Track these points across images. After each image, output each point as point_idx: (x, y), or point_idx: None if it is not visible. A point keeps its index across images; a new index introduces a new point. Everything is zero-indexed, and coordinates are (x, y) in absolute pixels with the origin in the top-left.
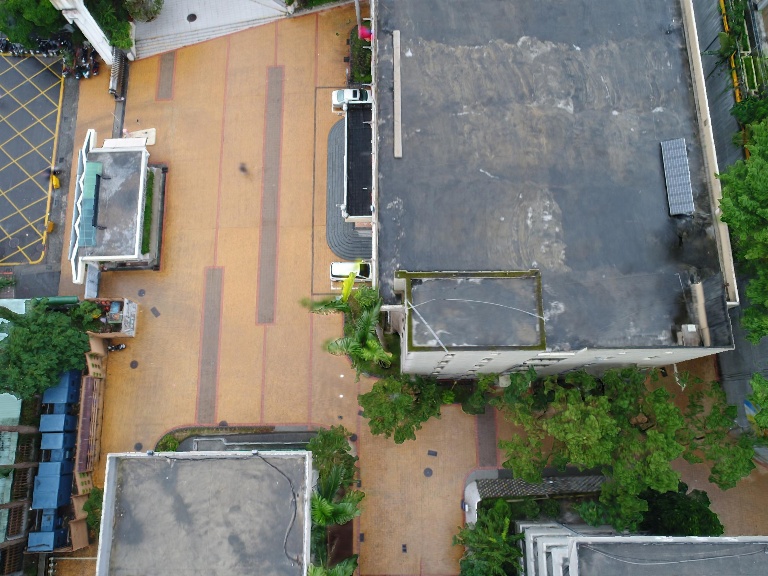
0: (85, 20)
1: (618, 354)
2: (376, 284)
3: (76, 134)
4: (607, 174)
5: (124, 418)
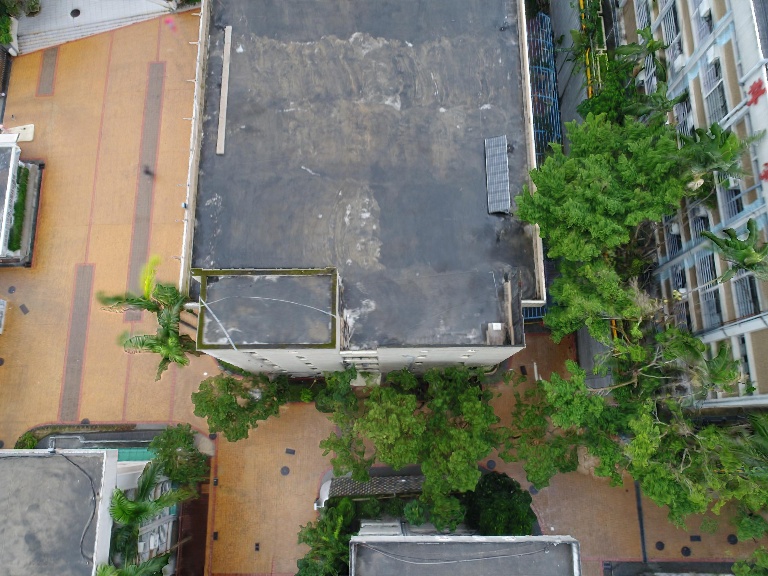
0: None
1: (421, 352)
2: (187, 281)
3: None
4: (429, 171)
5: None
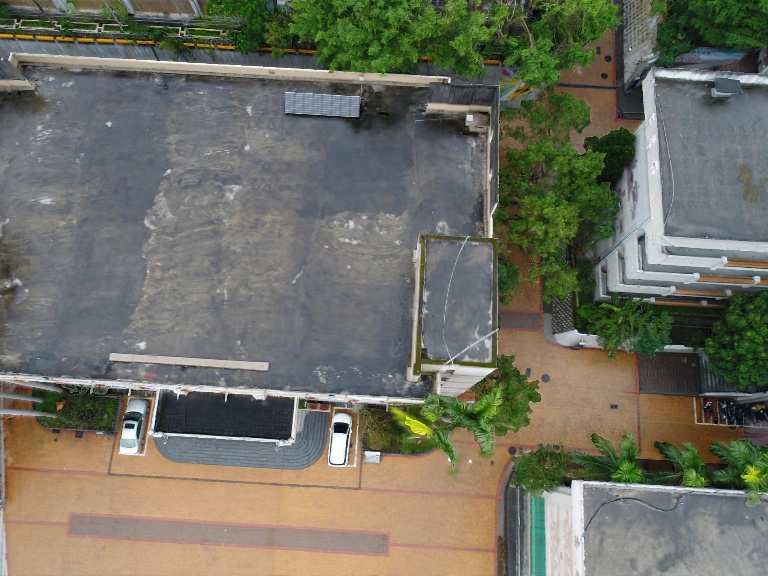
0: None
1: None
2: None
3: None
4: (311, 165)
5: None
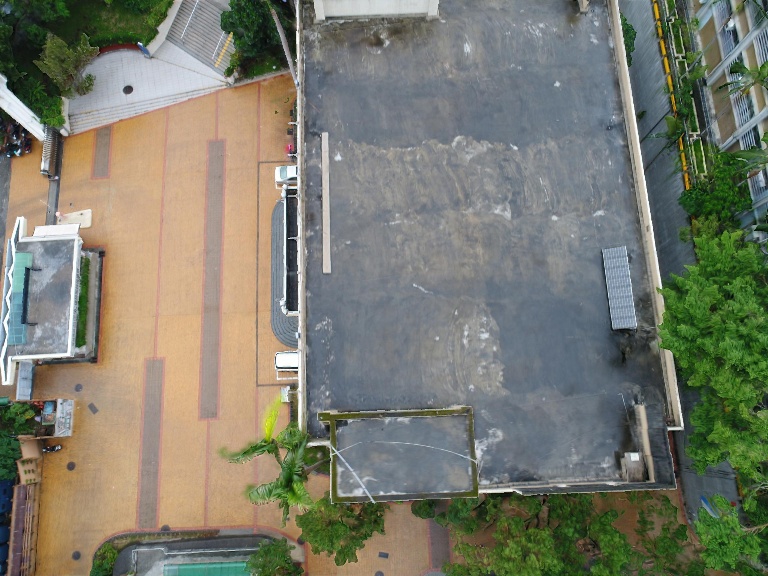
0: (9, 104)
1: None
2: (304, 416)
3: (8, 216)
4: (546, 286)
5: (61, 525)
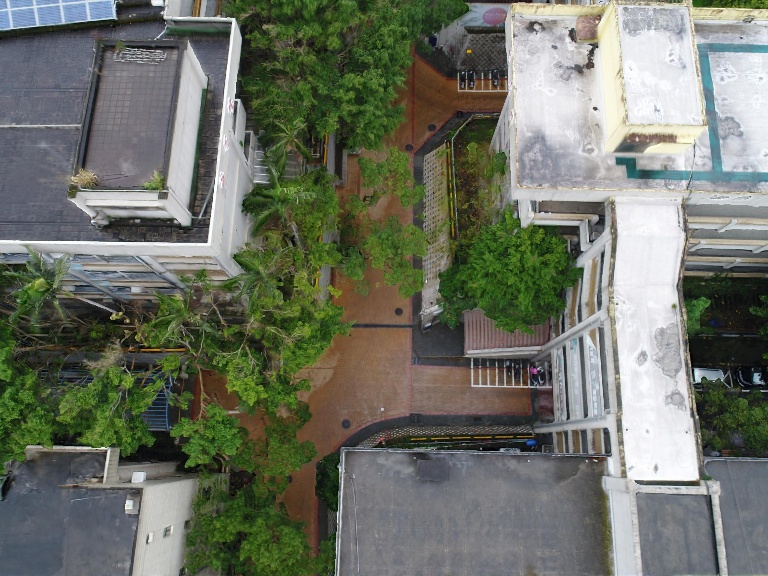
0: None
1: None
2: None
3: None
4: None
5: None
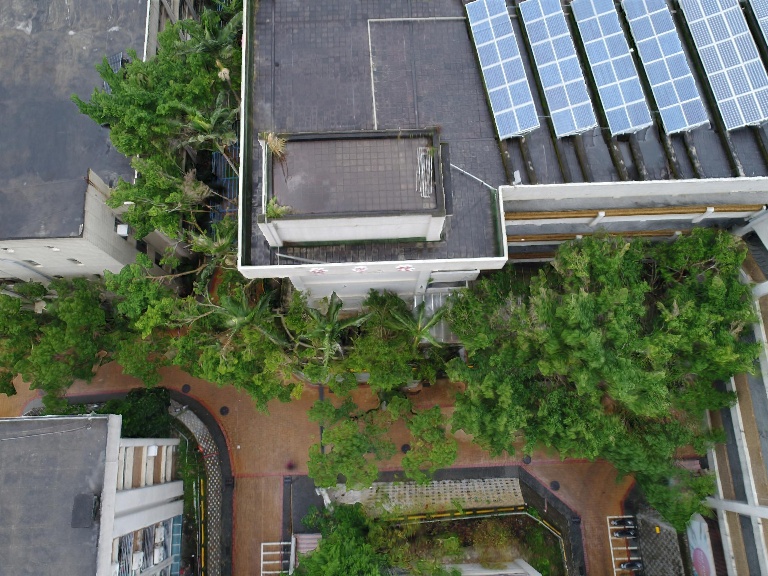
0: None
1: (8, 253)
2: None
3: None
4: (50, 89)
5: None
